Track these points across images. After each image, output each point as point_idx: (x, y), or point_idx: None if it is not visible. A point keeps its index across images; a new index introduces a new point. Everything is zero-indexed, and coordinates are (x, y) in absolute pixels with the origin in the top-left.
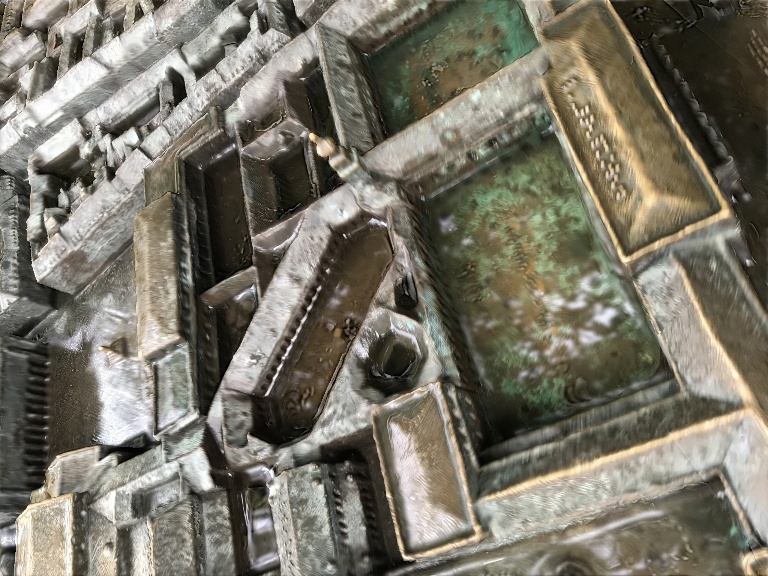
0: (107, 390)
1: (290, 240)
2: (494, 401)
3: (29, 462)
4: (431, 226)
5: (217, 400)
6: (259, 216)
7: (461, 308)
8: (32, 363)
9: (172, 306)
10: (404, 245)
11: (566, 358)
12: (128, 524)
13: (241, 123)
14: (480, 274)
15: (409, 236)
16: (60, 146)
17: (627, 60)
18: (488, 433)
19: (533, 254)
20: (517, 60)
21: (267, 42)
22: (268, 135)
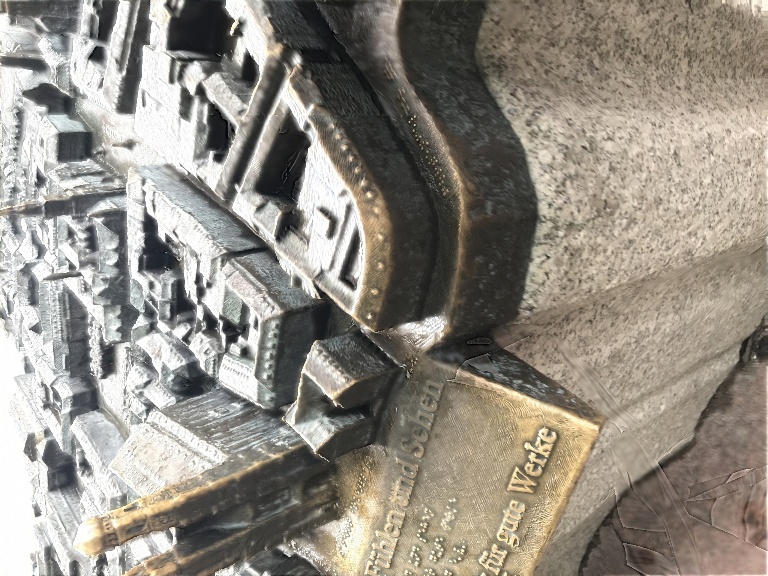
0: None
1: None
2: None
3: None
4: None
5: None
6: None
7: None
8: None
9: None
10: None
11: None
12: None
13: None
14: None
15: None
16: None
17: None
18: None
19: None
20: None
21: None
22: None
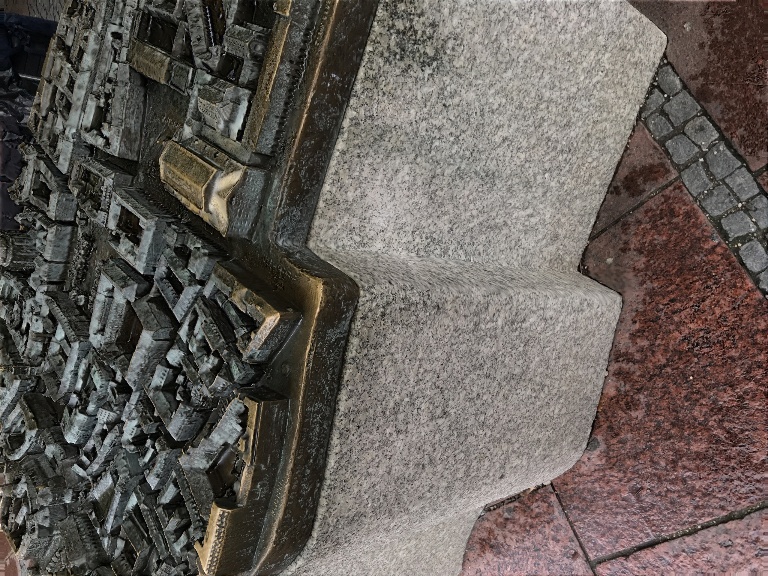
0: None
1: None
2: None
3: None
4: None
5: (195, 59)
6: None
7: None
8: None
9: (161, 55)
10: None
11: None
12: (198, 130)
13: (147, 2)
14: None
15: None
16: (91, 113)
17: None
18: None
19: None
20: None
21: None
22: None
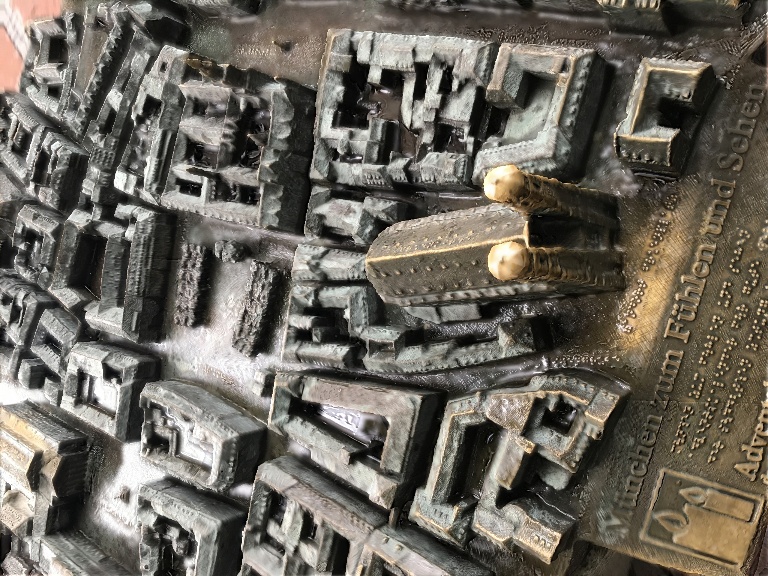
0: (116, 476)
1: None
2: None
3: None
4: None
5: (43, 573)
6: None
7: None
8: None
9: None
10: None
11: None
12: None
13: None
14: None
15: None
16: None
17: None
18: None
19: None
20: None
21: None
22: None
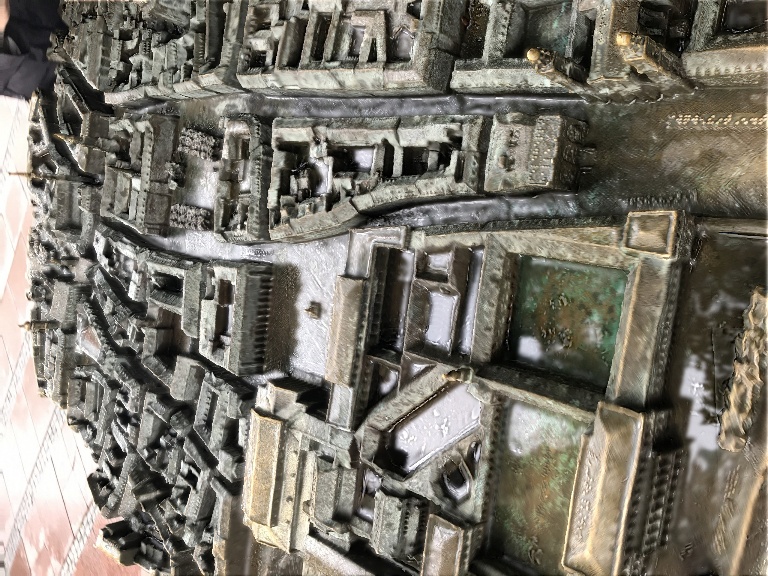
0: (305, 330)
1: (425, 366)
2: (498, 525)
3: (257, 346)
4: (510, 408)
5: (362, 429)
6: (412, 334)
7: (504, 468)
8: (263, 281)
9: (348, 367)
10: (483, 430)
11: (540, 536)
12: None
13: (420, 252)
14: (522, 458)
15: (488, 426)
16: (296, 137)
17: (626, 473)
18: (484, 546)
19: (553, 474)
20: (579, 409)
21: (458, 188)
22: (433, 283)
